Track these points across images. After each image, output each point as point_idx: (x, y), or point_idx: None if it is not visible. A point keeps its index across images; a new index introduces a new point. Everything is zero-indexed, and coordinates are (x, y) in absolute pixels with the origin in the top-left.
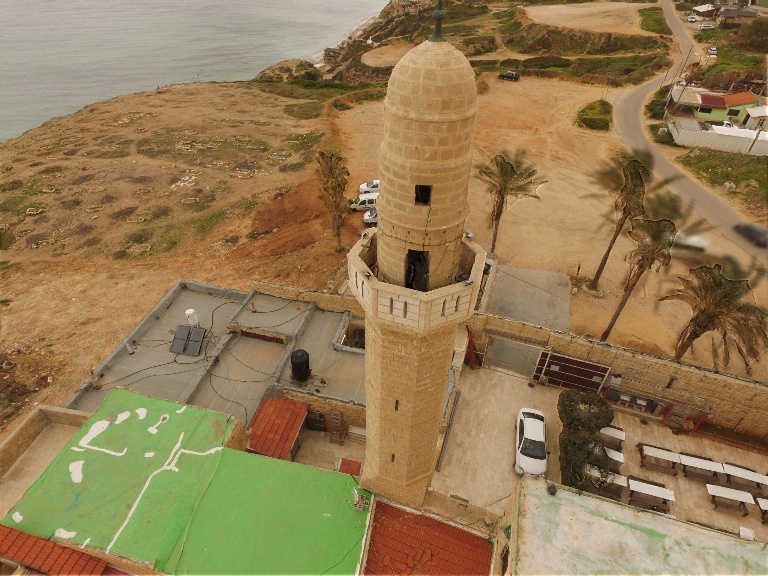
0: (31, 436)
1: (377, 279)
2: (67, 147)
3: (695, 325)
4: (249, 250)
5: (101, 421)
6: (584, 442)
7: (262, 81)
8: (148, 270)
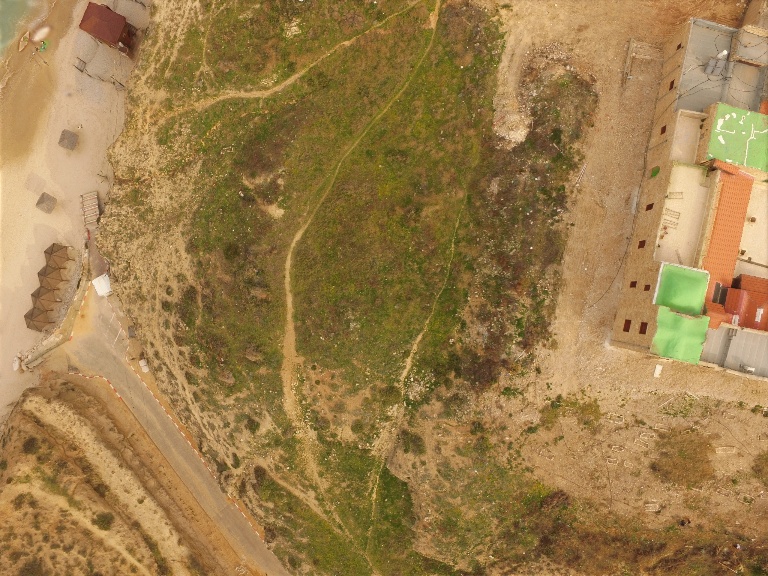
0: None
1: None
2: None
3: None
4: None
5: (720, 119)
6: None
7: None
8: None
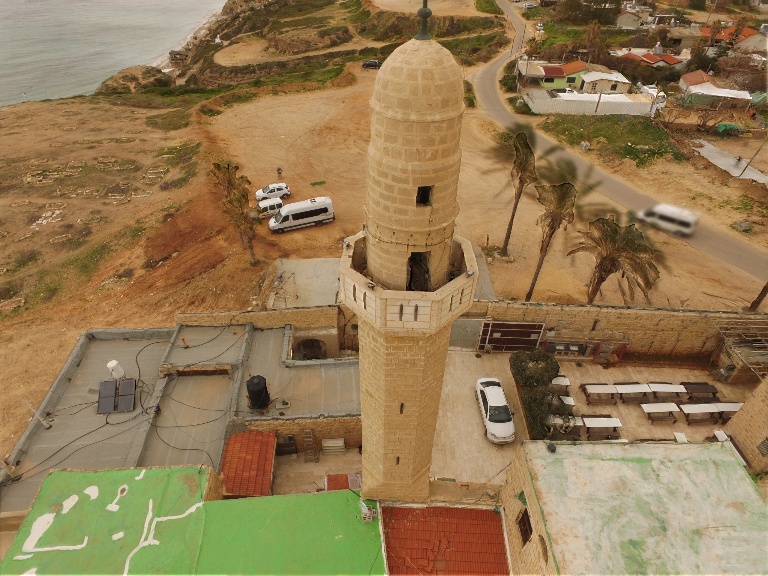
0: None
1: (381, 288)
2: None
3: (601, 271)
4: (150, 281)
5: (43, 516)
6: (543, 396)
7: (109, 93)
8: (29, 327)
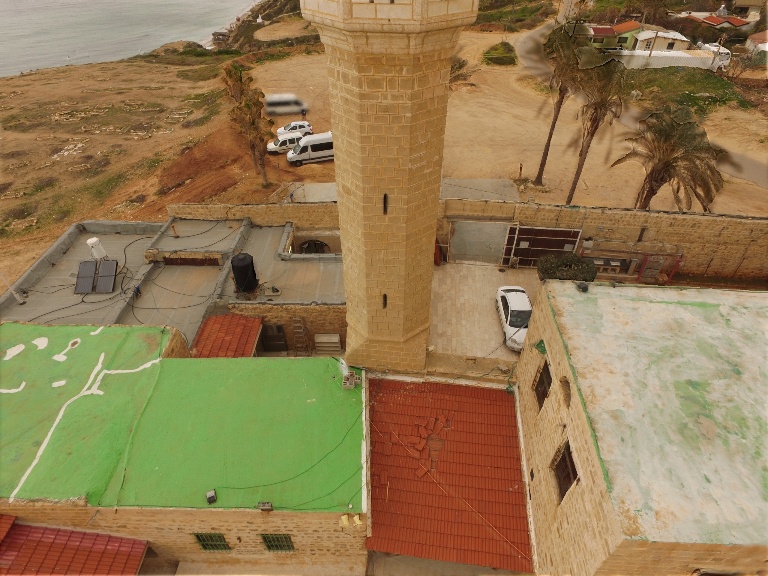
0: None
1: None
2: None
3: (651, 180)
4: (160, 205)
5: None
6: None
7: (147, 56)
8: (37, 243)
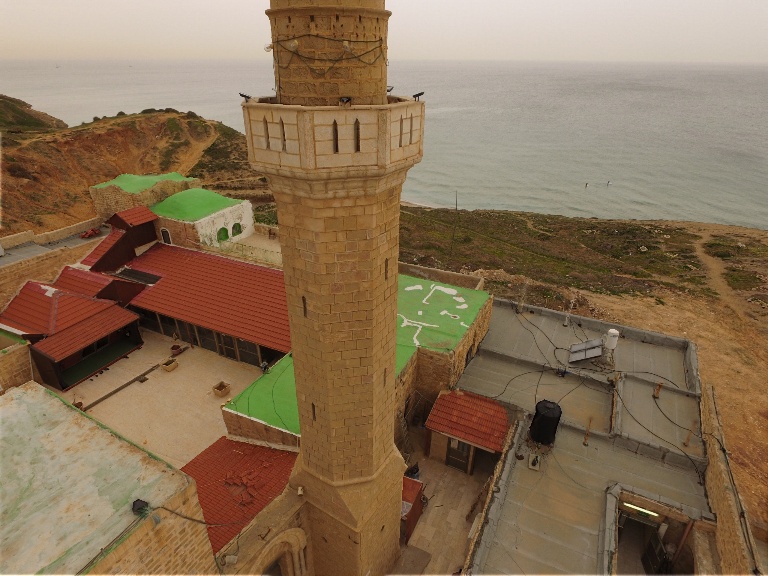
0: None
1: None
2: None
3: None
4: None
5: (456, 291)
6: None
7: None
8: None
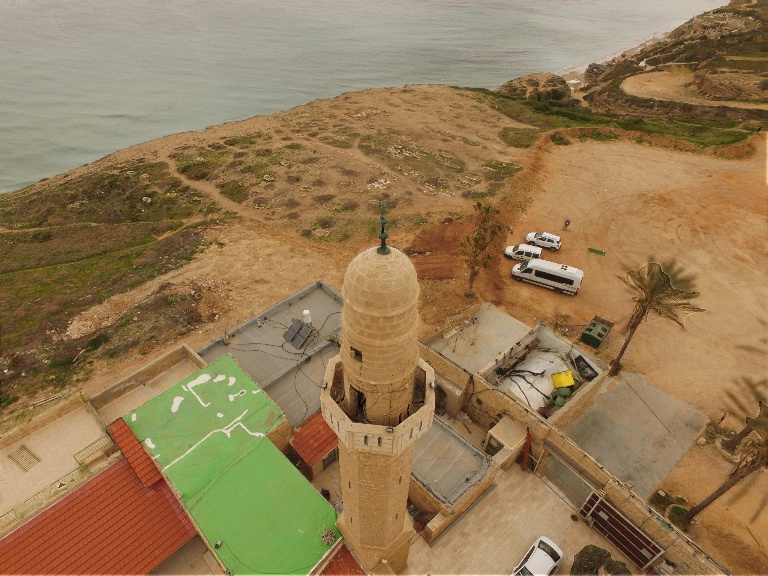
0: (173, 362)
1: (330, 393)
2: (313, 129)
3: None
4: None
5: (207, 375)
6: None
7: (498, 95)
8: (318, 253)
